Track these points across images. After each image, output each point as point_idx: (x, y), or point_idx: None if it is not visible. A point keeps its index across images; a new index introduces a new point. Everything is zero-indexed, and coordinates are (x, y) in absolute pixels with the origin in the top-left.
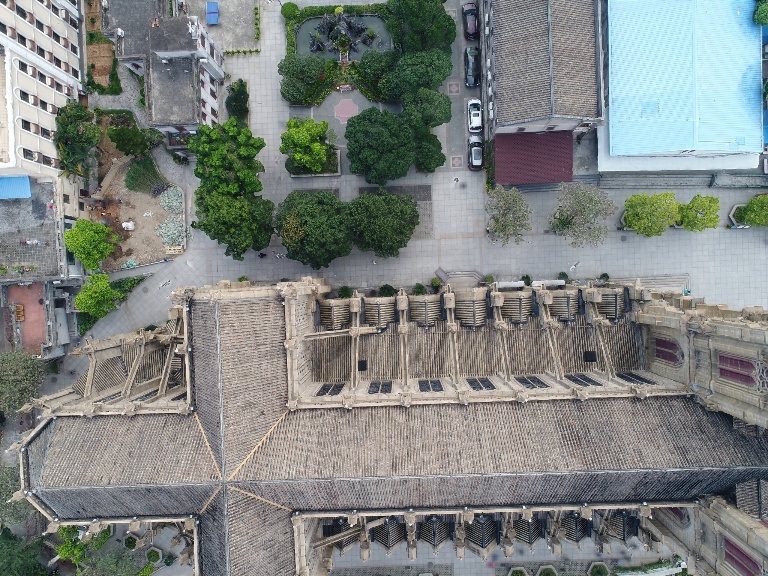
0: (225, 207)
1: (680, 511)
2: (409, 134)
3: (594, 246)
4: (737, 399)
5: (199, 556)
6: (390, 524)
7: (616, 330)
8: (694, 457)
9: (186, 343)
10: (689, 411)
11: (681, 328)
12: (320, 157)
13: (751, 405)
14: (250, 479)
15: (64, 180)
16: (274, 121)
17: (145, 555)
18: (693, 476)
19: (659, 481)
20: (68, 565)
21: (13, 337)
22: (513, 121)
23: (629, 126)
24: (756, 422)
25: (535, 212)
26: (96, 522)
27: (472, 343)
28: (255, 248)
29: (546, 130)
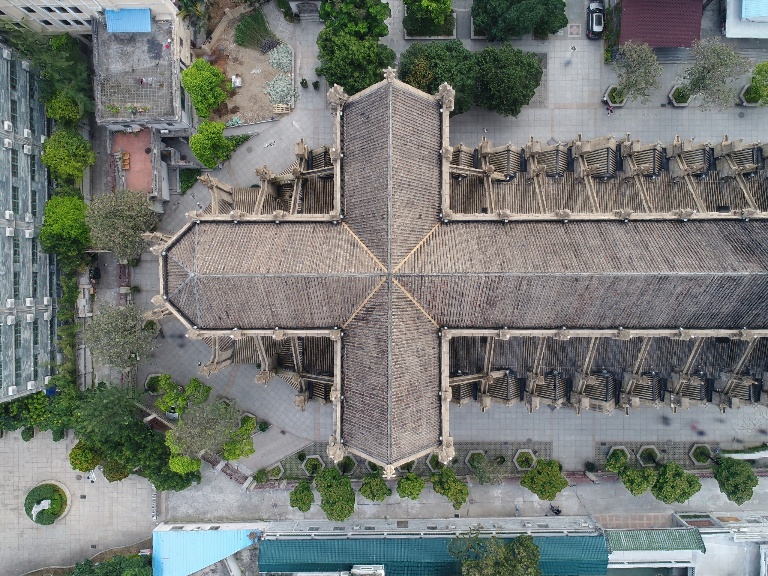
0: (354, 45)
1: None
2: None
3: (724, 108)
4: None
5: None
6: (510, 377)
7: (750, 186)
8: None
9: (338, 148)
10: None
11: None
12: (447, 6)
13: None
14: (416, 272)
15: (180, 22)
16: None
17: (238, 421)
18: None
19: None
20: (161, 426)
21: (116, 187)
22: None
23: None
24: None
25: None
26: (237, 330)
27: (602, 194)
28: None
29: None
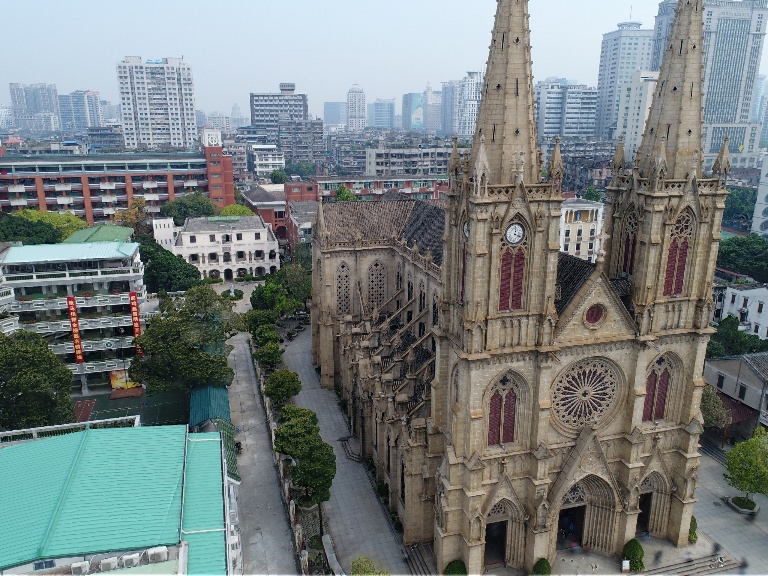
0: None
1: None
2: None
3: None
4: None
5: None
6: None
7: None
8: None
9: None
10: None
11: None
12: None
13: None
14: None
15: None
16: None
17: None
18: None
19: None
20: None
21: None
22: None
23: None
24: None
25: None
26: None
27: None
28: None
29: (739, 399)
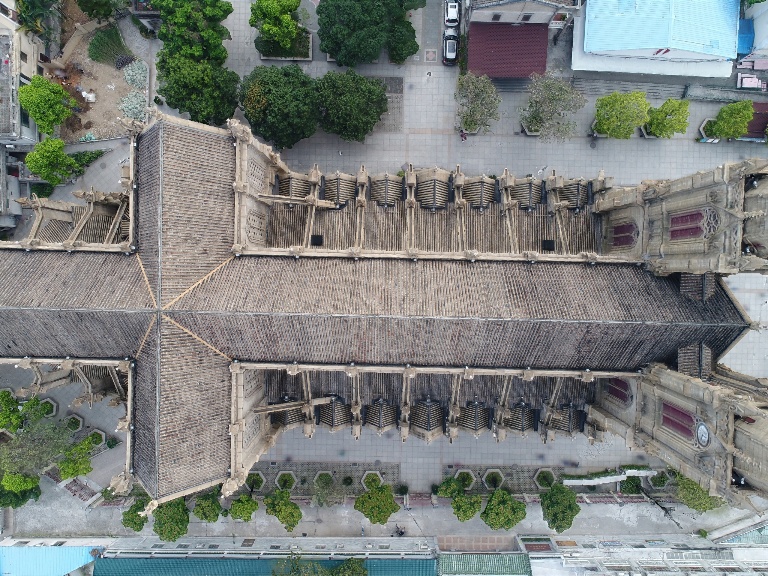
0: (187, 68)
1: (625, 393)
2: (382, 13)
3: (561, 141)
4: (684, 254)
5: (133, 402)
6: (336, 403)
7: (576, 221)
8: (638, 313)
9: (131, 180)
10: (638, 277)
11: (637, 198)
12: (289, 30)
13: (697, 253)
14: (186, 309)
15: (22, 37)
16: (247, 0)
17: None
18: (636, 333)
19: (602, 339)
20: (7, 441)
21: None
22: (488, 3)
23: (605, 22)
24: (700, 267)
25: (506, 113)
26: (27, 358)
27: (431, 225)
28: (217, 121)
29: (522, 21)
